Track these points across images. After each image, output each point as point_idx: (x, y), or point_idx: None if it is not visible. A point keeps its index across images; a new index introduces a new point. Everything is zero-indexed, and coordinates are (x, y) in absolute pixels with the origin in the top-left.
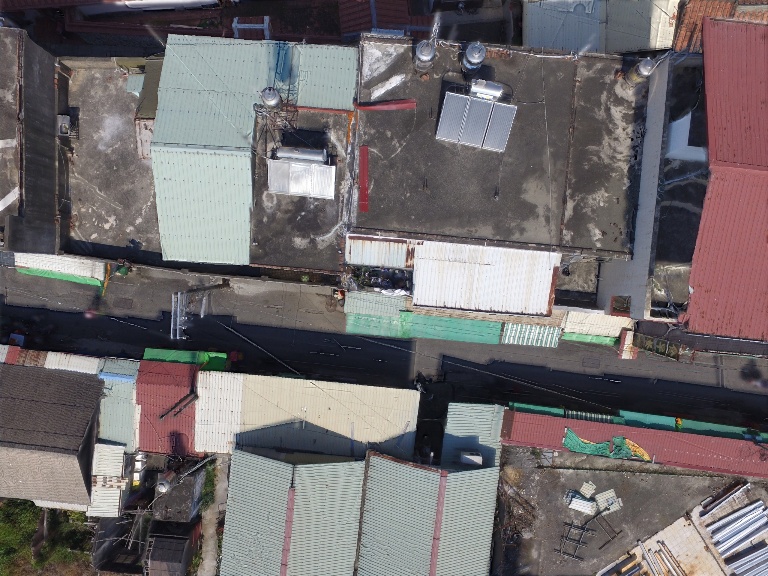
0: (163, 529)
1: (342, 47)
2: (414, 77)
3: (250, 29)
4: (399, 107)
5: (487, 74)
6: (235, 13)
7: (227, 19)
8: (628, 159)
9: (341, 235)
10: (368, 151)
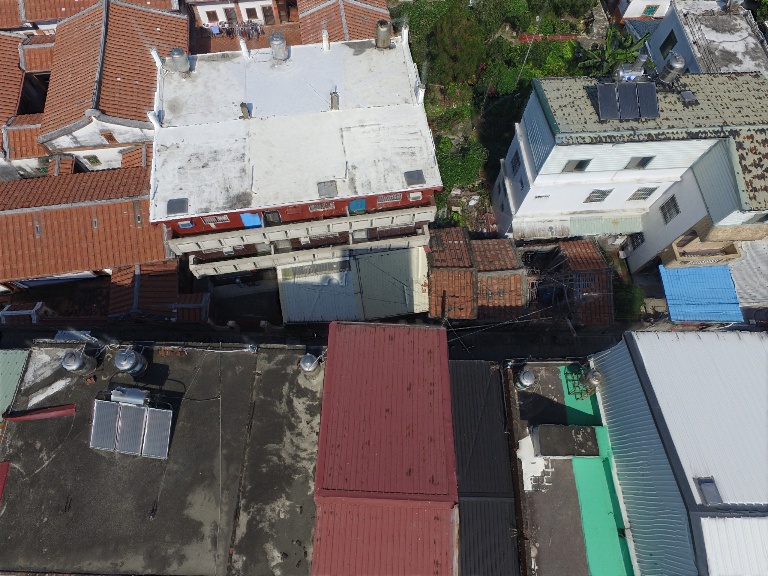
0: None
1: (22, 351)
2: (80, 380)
3: (17, 315)
4: (54, 415)
5: (160, 372)
6: (25, 297)
7: (17, 302)
8: (313, 457)
9: None
10: (9, 467)
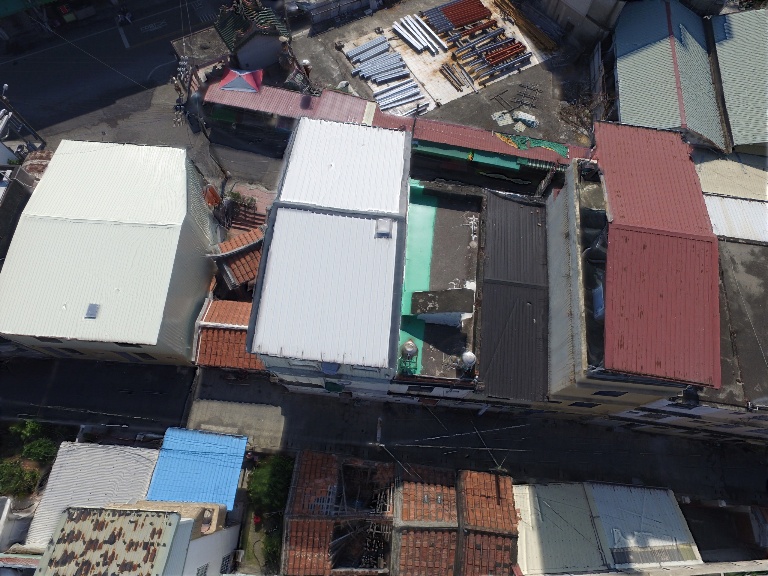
0: None
1: None
2: None
3: None
4: None
5: None
6: None
7: None
8: None
9: None
10: None
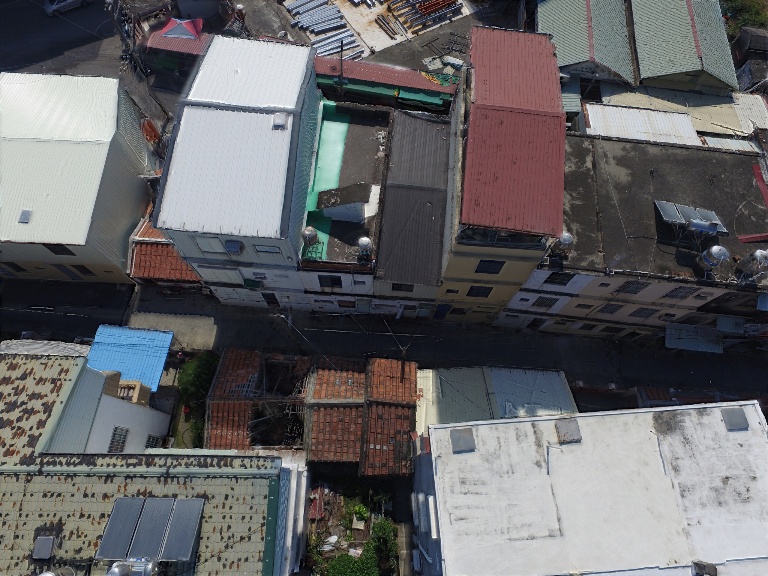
0: (763, 58)
1: None
2: None
3: None
4: None
5: (682, 261)
6: None
7: None
8: None
9: (767, 152)
10: (766, 207)
